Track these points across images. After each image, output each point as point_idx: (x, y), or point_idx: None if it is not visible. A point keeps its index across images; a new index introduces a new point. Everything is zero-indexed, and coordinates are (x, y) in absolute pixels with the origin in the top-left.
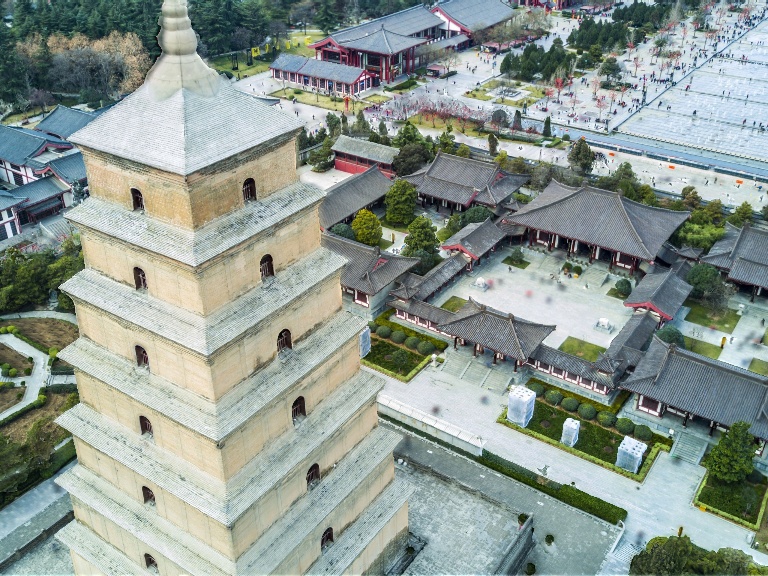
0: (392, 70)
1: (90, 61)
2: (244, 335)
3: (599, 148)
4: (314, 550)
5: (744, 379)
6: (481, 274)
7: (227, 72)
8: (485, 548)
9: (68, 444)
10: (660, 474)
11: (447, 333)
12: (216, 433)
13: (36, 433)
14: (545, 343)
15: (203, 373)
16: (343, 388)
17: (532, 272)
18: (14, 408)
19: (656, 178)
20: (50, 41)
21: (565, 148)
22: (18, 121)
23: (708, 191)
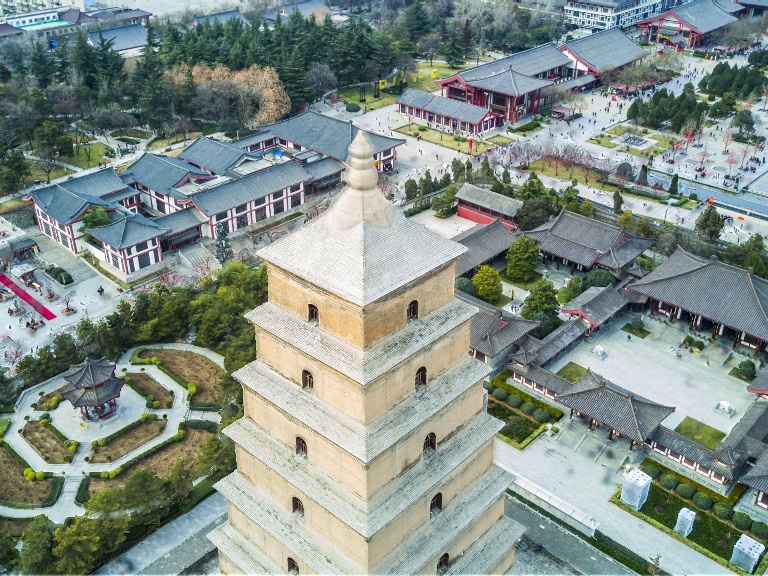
0: (517, 111)
1: (230, 93)
2: (397, 441)
3: (728, 210)
4: None
5: None
6: (599, 340)
7: (355, 105)
8: None
9: (204, 481)
10: None
11: (564, 405)
12: (367, 530)
13: (179, 471)
14: (663, 424)
15: (359, 474)
16: (476, 483)
17: (652, 343)
18: (157, 440)
19: None
20: (195, 70)
21: (692, 208)
22: (162, 147)
23: None
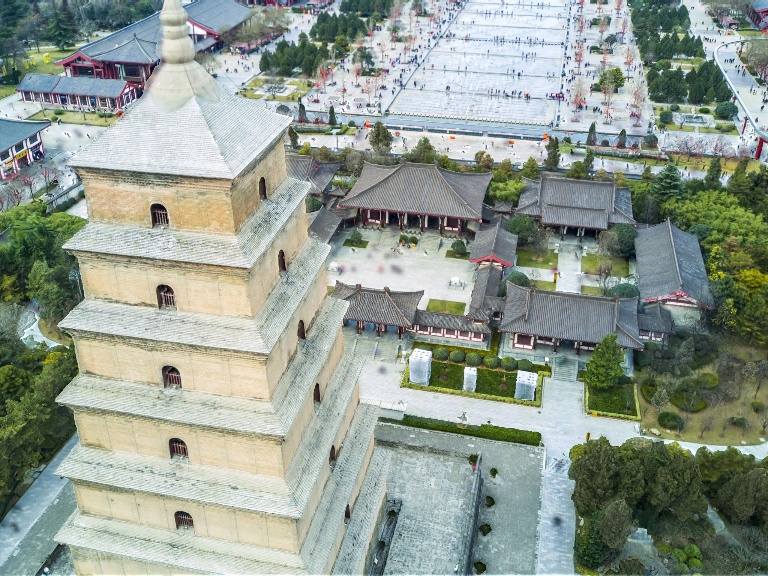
0: None
1: None
2: None
3: None
4: (342, 529)
5: (595, 301)
6: (329, 260)
7: None
8: (452, 493)
9: None
10: (551, 396)
11: None
12: (281, 429)
13: None
14: (418, 308)
15: (256, 374)
16: (337, 370)
17: (374, 249)
18: None
19: (450, 148)
20: None
21: (355, 133)
22: None
23: (497, 153)
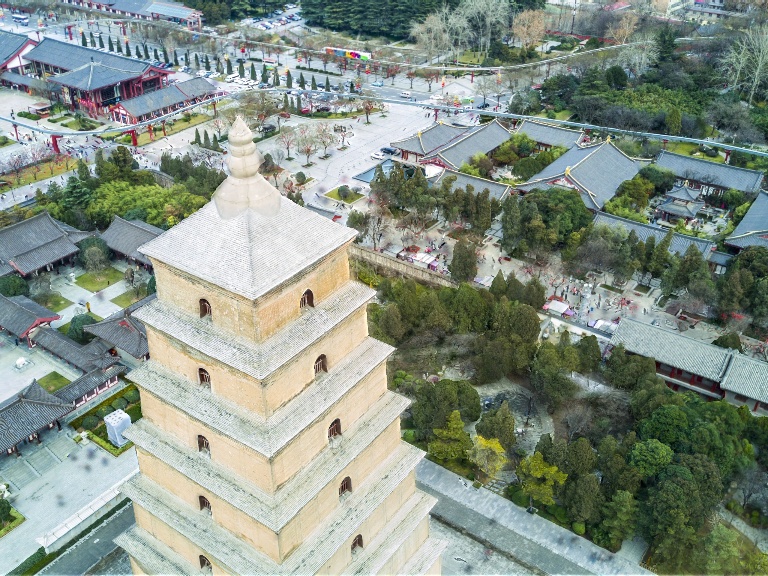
0: None
1: None
2: None
3: None
4: None
5: None
6: None
7: None
8: None
9: None
10: None
11: None
12: (408, 400)
13: None
14: None
15: None
16: None
17: None
18: None
19: None
20: None
21: None
22: None
23: None
